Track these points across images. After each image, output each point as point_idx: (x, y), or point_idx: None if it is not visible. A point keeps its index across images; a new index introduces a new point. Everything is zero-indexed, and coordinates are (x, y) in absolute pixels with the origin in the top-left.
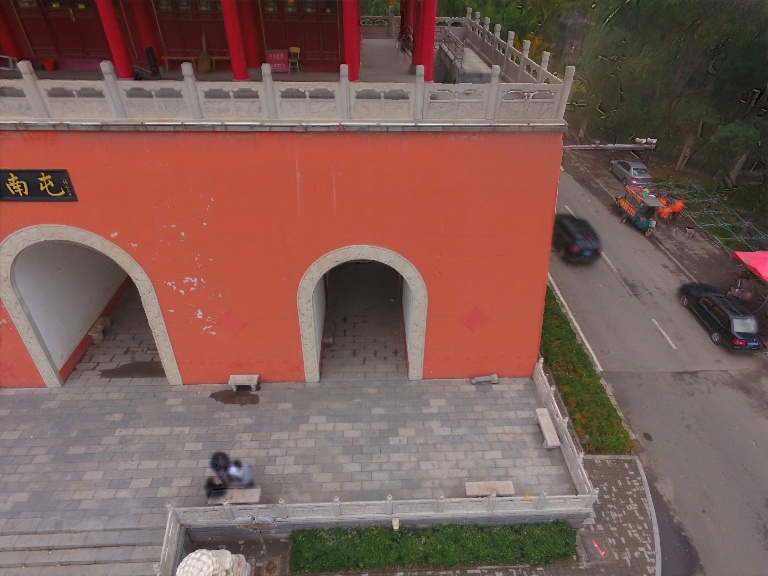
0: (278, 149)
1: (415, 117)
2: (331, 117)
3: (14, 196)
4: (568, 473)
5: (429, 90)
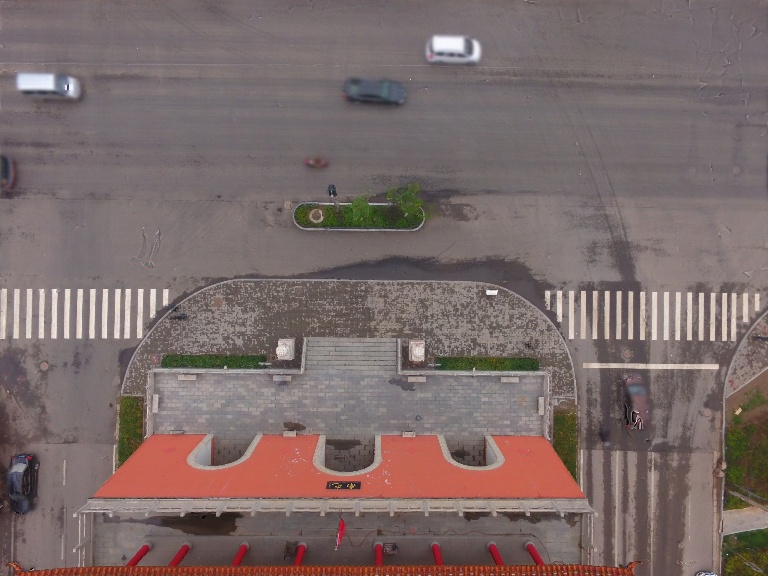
0: (228, 494)
1: (159, 503)
2: (198, 503)
3: (355, 483)
4: (155, 384)
5: (147, 509)
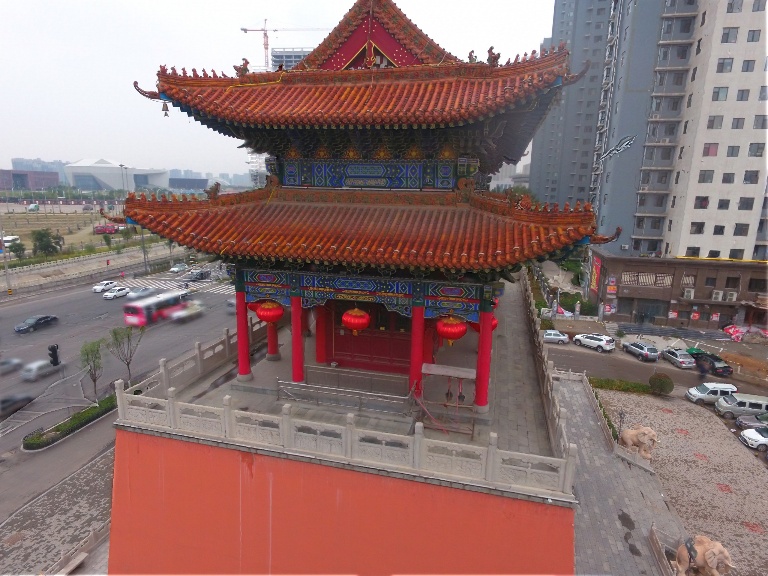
0: None
1: None
2: None
3: None
4: None
5: (194, 358)
